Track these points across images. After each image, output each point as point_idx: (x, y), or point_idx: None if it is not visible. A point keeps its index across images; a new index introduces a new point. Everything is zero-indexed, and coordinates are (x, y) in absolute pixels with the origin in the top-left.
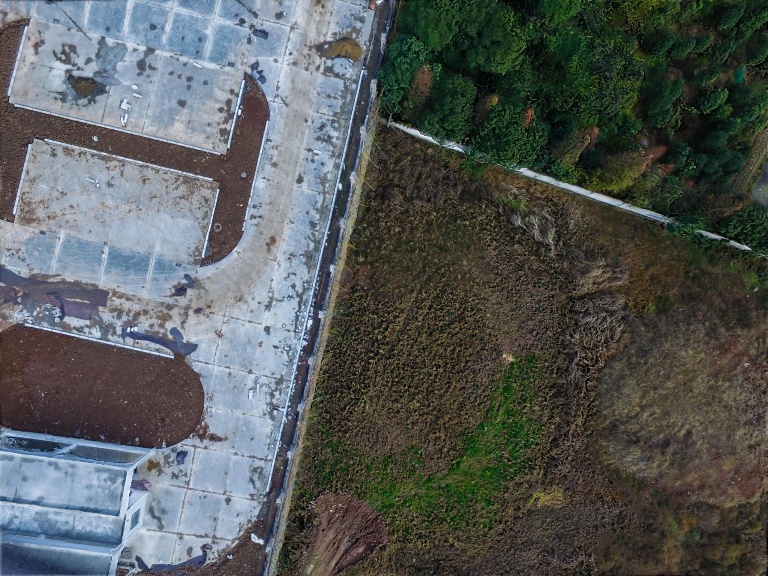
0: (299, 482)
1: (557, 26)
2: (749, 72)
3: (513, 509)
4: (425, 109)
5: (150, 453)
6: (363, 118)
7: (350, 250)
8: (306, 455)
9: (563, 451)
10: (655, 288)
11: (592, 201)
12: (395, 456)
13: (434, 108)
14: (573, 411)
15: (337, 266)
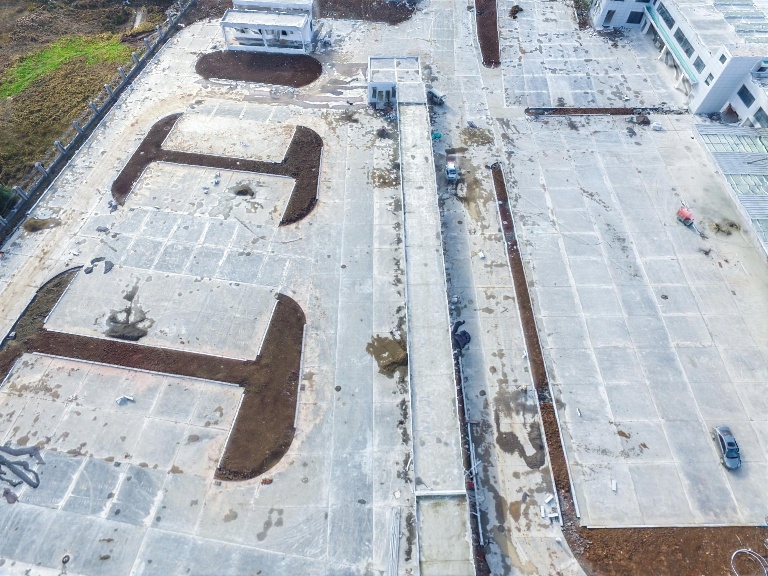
0: None
1: None
2: None
3: None
4: None
5: None
6: (42, 185)
7: None
8: None
9: None
10: None
11: None
12: (102, 61)
13: None
14: None
15: None
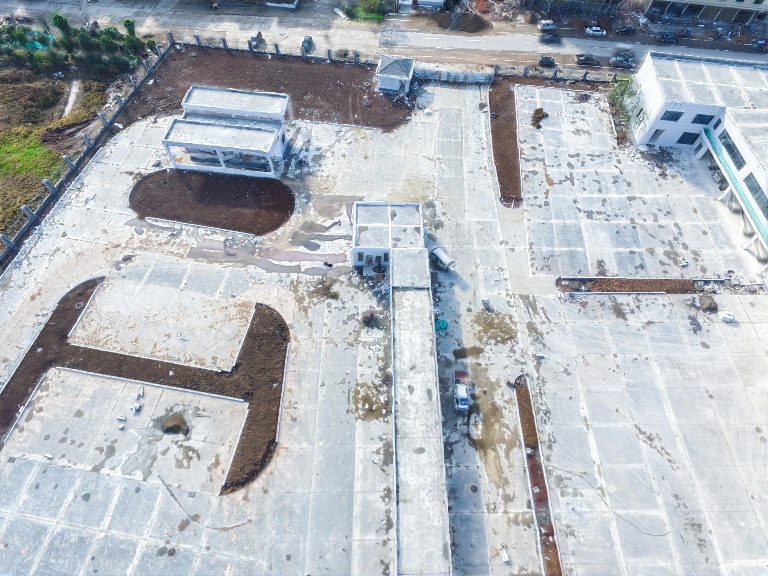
0: None
1: None
2: None
3: None
4: None
5: None
6: None
7: None
8: None
9: None
10: None
11: None
12: (13, 173)
13: None
14: None
15: None
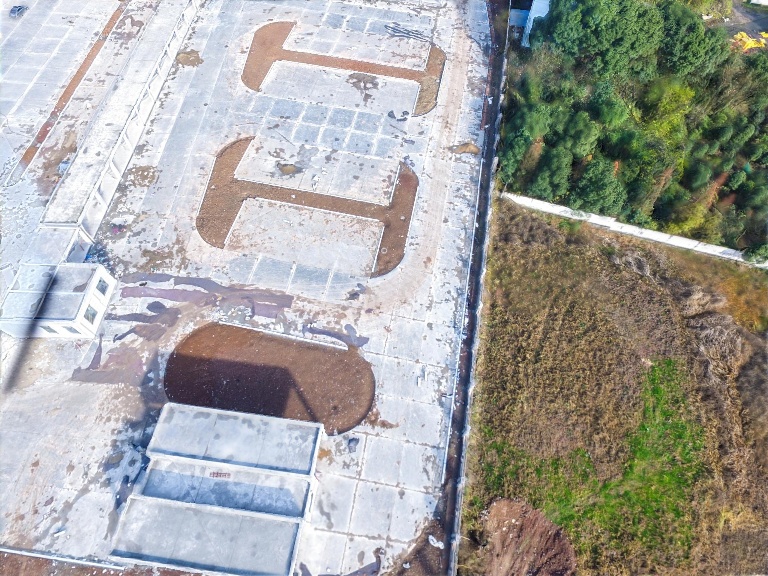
0: (469, 485)
1: (614, 128)
2: (753, 166)
3: (705, 529)
4: (536, 172)
5: (323, 438)
6: (488, 184)
7: (487, 275)
8: (472, 455)
9: (734, 461)
10: (754, 310)
11: (671, 247)
12: (563, 459)
13: (543, 170)
14: (727, 417)
15: (483, 277)
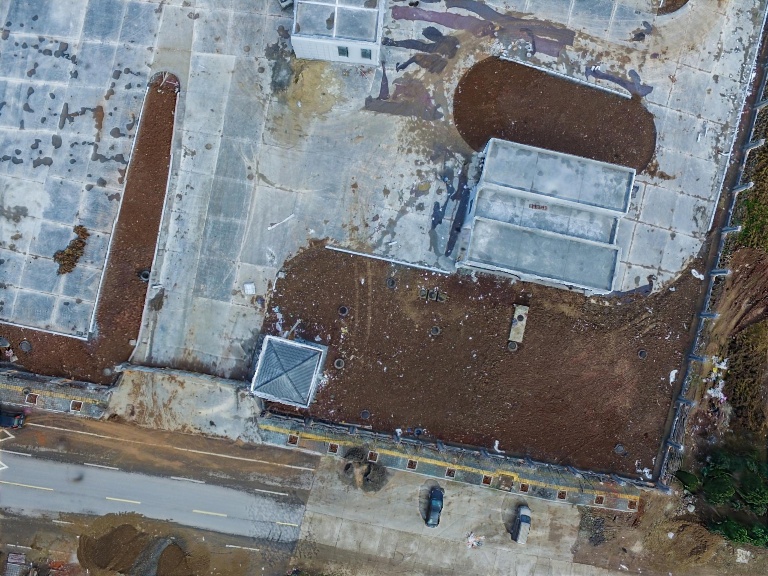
0: None
1: None
2: None
3: None
4: None
5: None
6: None
7: None
8: None
9: None
10: None
11: None
12: None
13: None
14: None
15: None
